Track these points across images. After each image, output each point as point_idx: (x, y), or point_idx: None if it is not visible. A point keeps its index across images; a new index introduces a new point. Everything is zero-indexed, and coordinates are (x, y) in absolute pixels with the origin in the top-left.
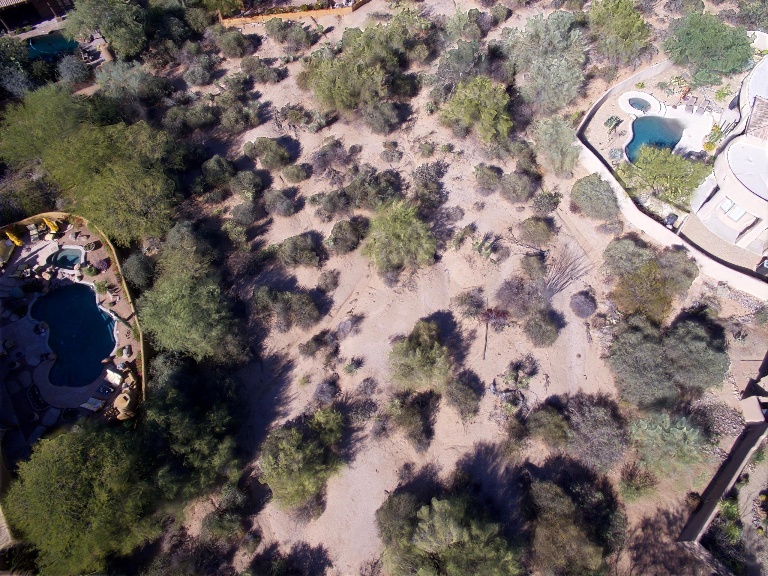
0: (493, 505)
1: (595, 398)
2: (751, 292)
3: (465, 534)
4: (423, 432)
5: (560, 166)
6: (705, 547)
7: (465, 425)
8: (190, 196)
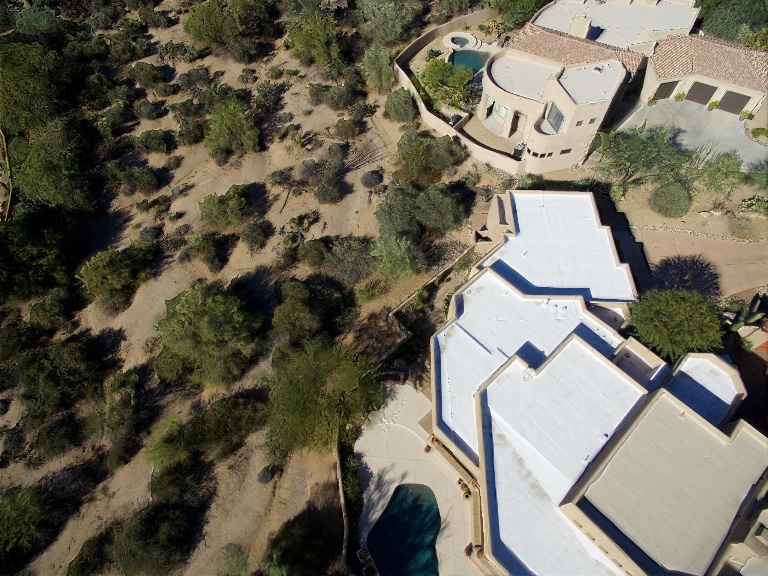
0: (258, 304)
1: (357, 236)
2: (505, 169)
3: (209, 299)
4: (217, 257)
5: (380, 84)
6: (396, 317)
7: (253, 255)
8: (77, 106)
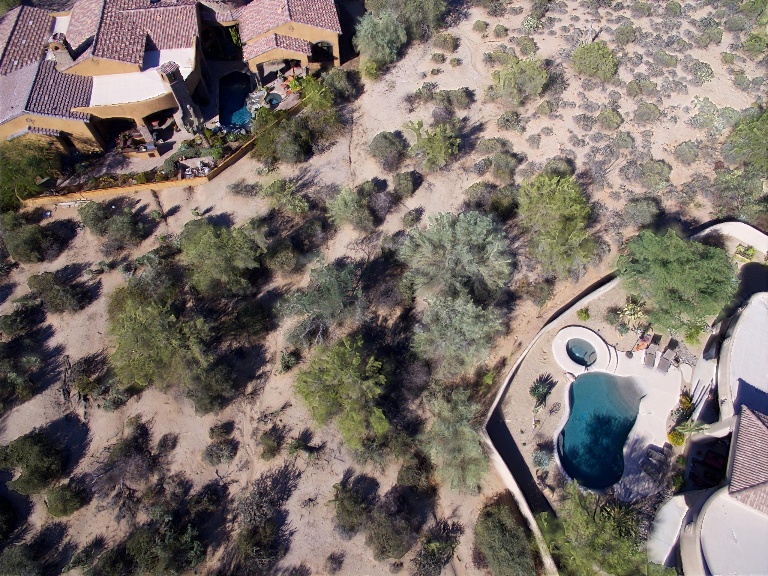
0: None
1: None
2: None
3: None
4: None
5: (461, 478)
6: None
7: None
8: None
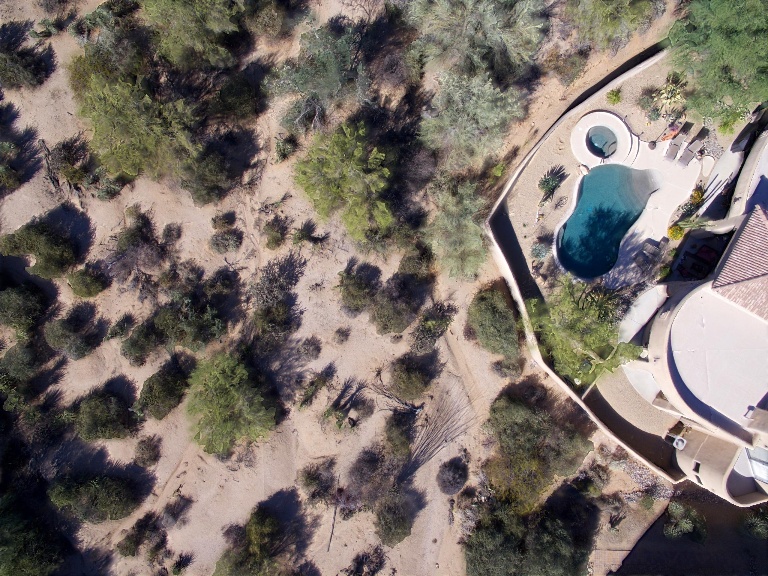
0: None
1: None
2: None
3: None
4: None
5: (460, 267)
6: None
7: None
8: None
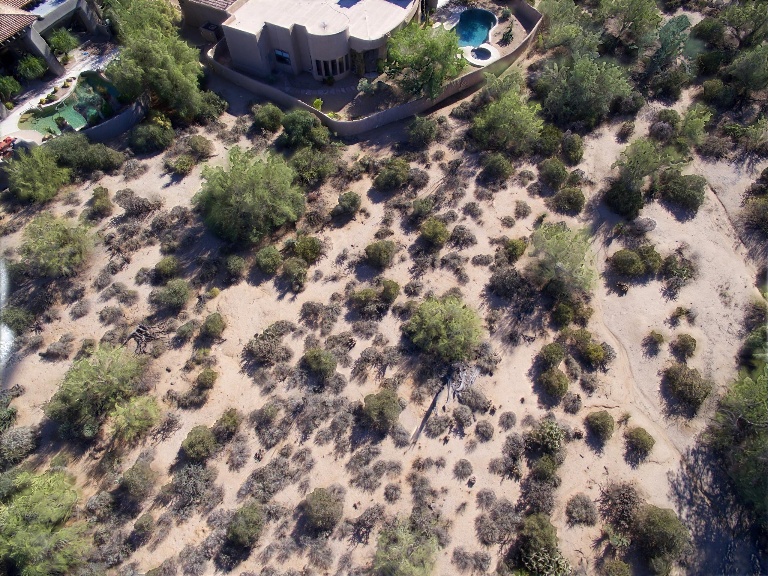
0: None
1: None
2: None
3: None
4: None
5: None
6: None
7: None
8: None
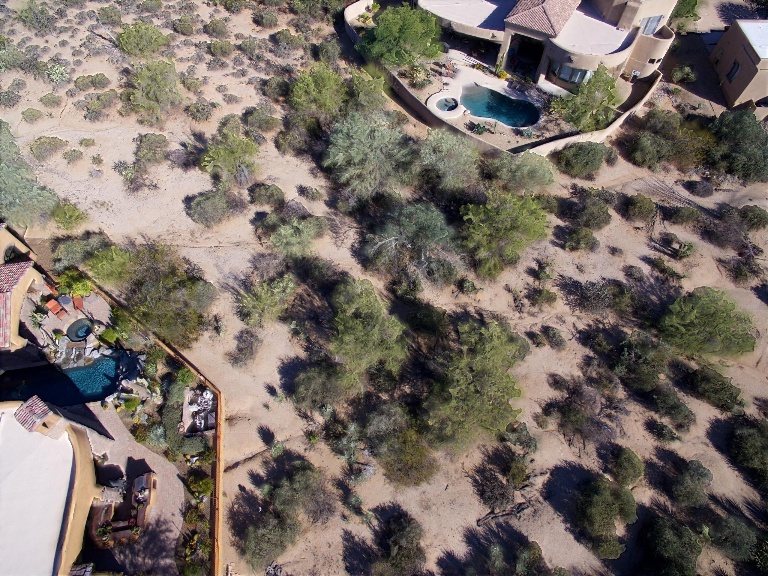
0: None
1: None
2: None
3: None
4: None
5: None
6: None
7: None
8: None
